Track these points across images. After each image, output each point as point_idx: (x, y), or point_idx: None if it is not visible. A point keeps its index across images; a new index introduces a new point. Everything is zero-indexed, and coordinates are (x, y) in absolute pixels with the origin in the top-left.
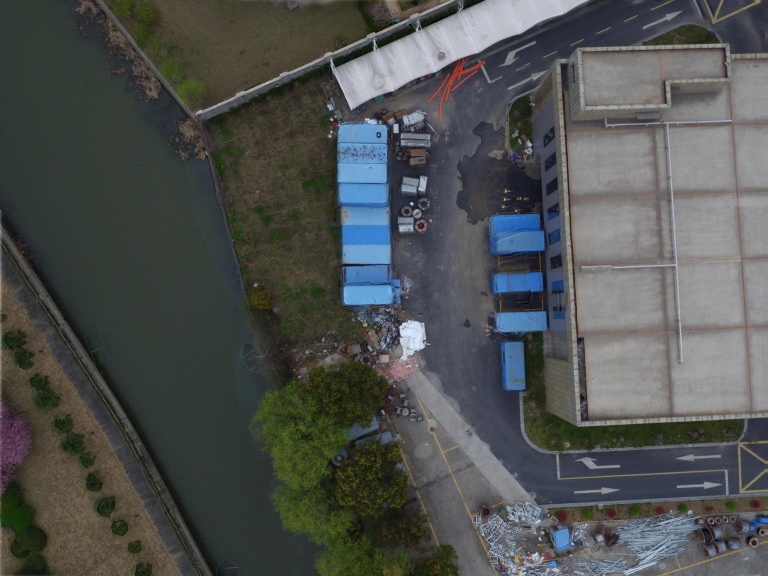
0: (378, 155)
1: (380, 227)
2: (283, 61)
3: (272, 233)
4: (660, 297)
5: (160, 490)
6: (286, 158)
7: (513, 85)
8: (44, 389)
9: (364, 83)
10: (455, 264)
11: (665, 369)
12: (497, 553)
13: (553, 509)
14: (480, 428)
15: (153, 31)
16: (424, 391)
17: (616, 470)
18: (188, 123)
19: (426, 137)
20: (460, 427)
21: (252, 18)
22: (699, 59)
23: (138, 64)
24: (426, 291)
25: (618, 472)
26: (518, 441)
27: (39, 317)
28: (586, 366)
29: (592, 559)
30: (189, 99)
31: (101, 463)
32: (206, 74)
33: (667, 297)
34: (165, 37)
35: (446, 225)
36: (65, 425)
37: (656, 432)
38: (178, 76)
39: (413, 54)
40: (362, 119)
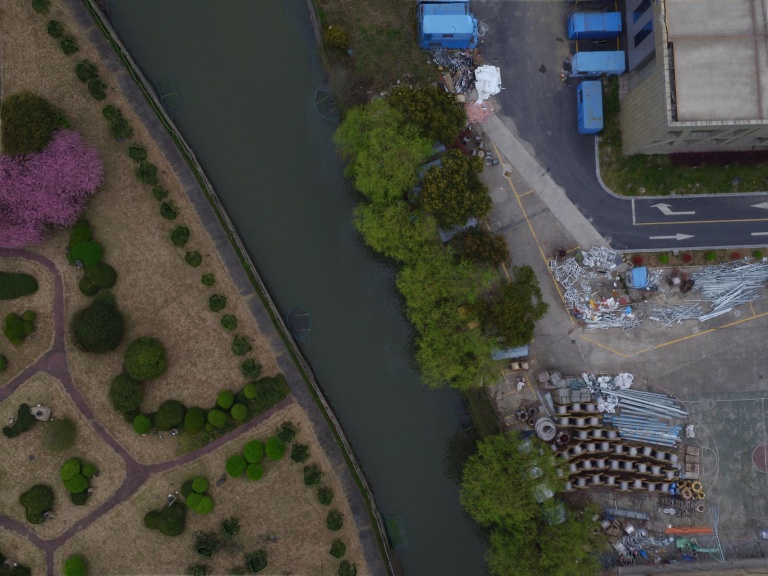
0: None
1: None
2: None
3: None
4: (748, 3)
5: (232, 230)
6: None
7: None
8: (118, 118)
9: None
10: (530, 11)
11: (753, 73)
12: (572, 297)
13: (628, 254)
14: (555, 172)
15: None
16: (499, 135)
17: (691, 216)
18: None
19: None
20: (535, 171)
21: None
22: None
23: None
24: (501, 36)
25: (693, 218)
26: (593, 185)
27: (110, 57)
28: (675, 69)
29: (667, 304)
30: None
31: (173, 201)
32: None
33: (755, 3)
34: None
35: None
36: (140, 151)
37: (731, 178)
38: None
39: None
40: None
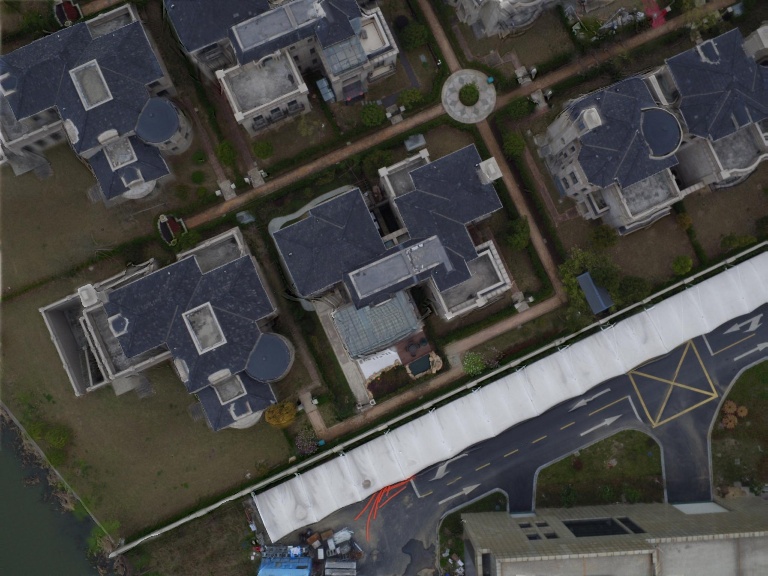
0: None
1: None
2: (202, 482)
3: None
4: None
5: None
6: None
7: (444, 499)
8: None
9: (285, 515)
10: None
11: None
12: None
13: None
14: None
15: (66, 452)
16: None
17: None
18: (106, 539)
19: (351, 566)
20: None
21: (170, 435)
22: (625, 565)
23: (53, 474)
24: None
25: None
26: None
27: None
28: None
29: None
30: (105, 520)
31: None
32: (122, 496)
33: None
34: (79, 456)
35: None
36: None
37: None
38: (93, 497)
39: (337, 482)
40: (285, 546)
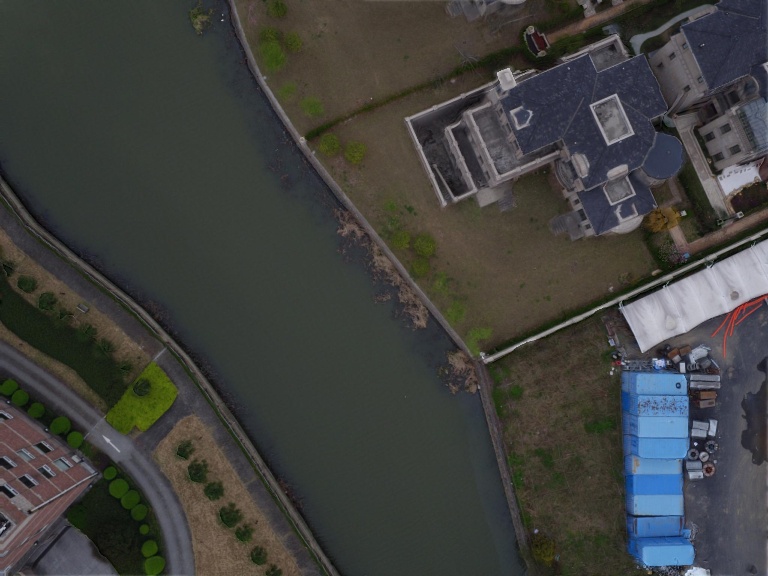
0: (679, 408)
1: (672, 476)
2: (565, 295)
3: (555, 478)
4: None
5: None
6: (568, 397)
7: None
8: None
9: (656, 325)
10: (740, 507)
11: None
12: None
13: None
14: None
15: (429, 263)
16: None
17: None
18: (459, 355)
19: (716, 379)
20: None
21: (531, 248)
22: None
23: (405, 291)
24: (711, 536)
25: None
26: None
27: (309, 565)
28: None
29: None
30: (465, 334)
31: None
32: (484, 308)
33: None
34: (440, 268)
35: (731, 466)
36: None
37: None
38: (454, 310)
39: (705, 293)
40: (649, 359)
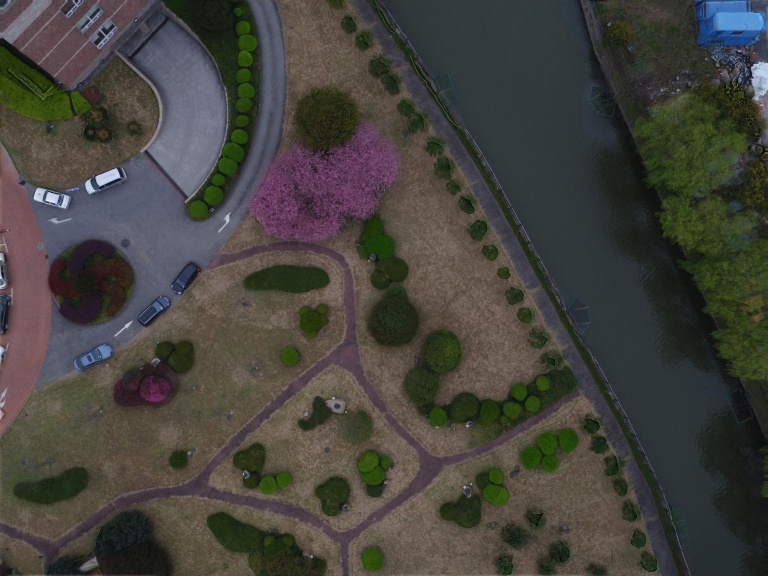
0: None
1: None
2: None
3: None
4: None
5: None
6: None
7: None
8: (414, 113)
9: None
10: None
11: None
12: None
13: None
14: None
15: None
16: None
17: None
18: None
19: None
20: None
21: None
22: None
23: None
24: None
25: None
26: None
27: (393, 53)
28: None
29: None
30: None
31: None
32: None
33: None
34: None
35: None
36: (439, 146)
37: None
38: None
39: None
40: None
